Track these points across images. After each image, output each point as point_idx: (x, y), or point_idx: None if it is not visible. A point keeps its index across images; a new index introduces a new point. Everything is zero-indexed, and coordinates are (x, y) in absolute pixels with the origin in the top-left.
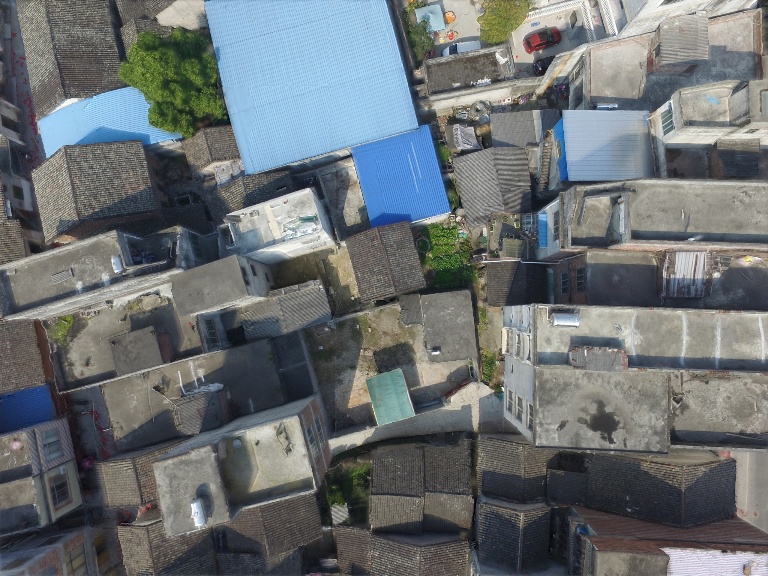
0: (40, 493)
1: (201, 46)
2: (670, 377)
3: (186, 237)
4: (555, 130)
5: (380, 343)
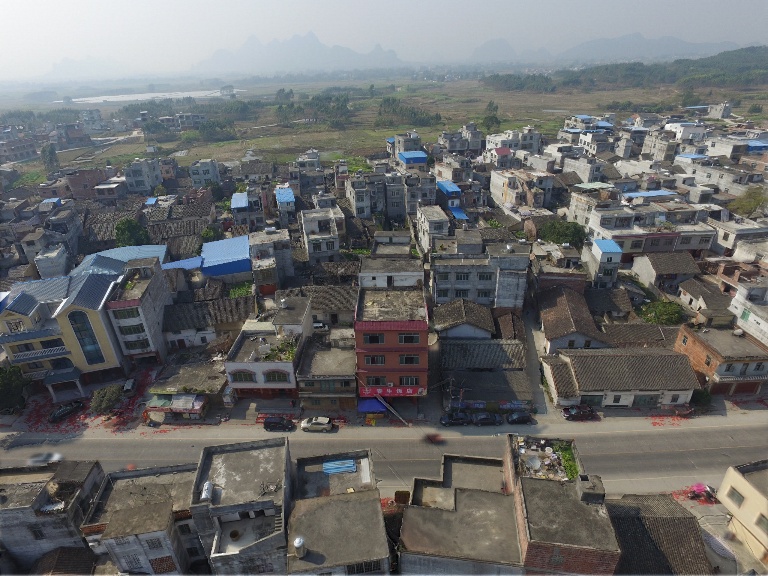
0: (3, 225)
1: None
2: None
3: (63, 239)
4: None
5: None
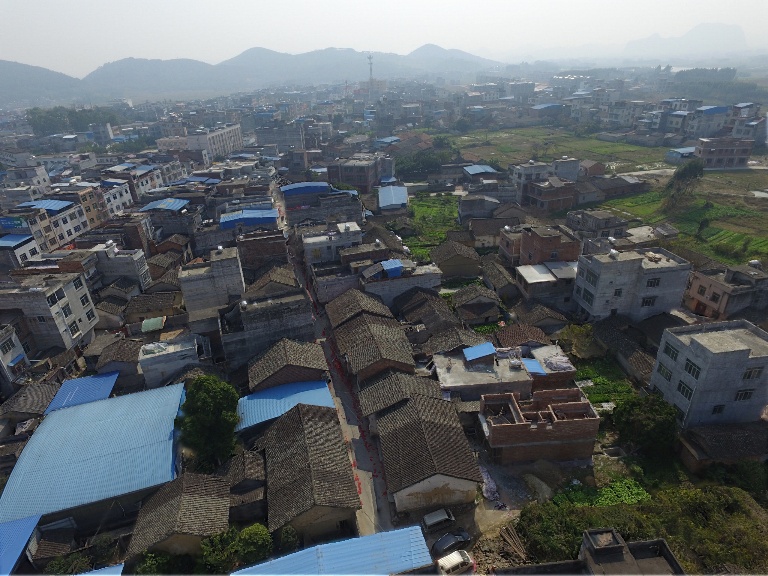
0: None
1: None
2: None
3: None
4: None
5: None
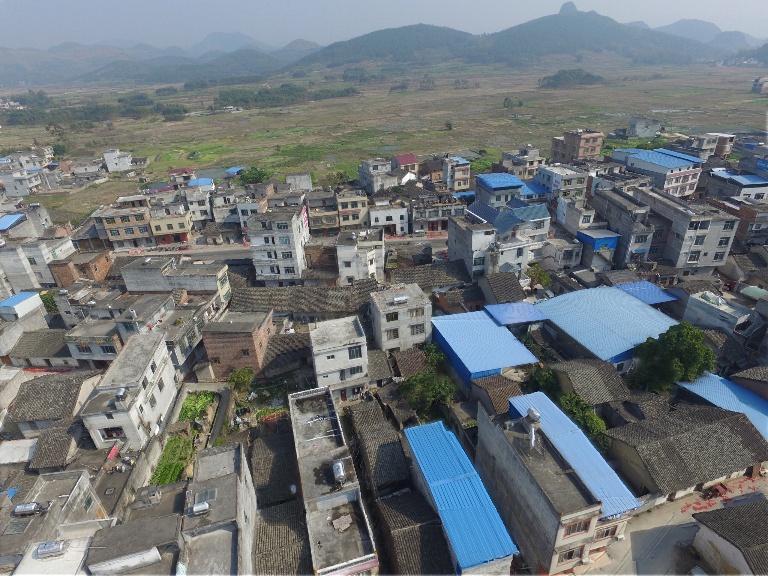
0: None
1: None
2: None
3: None
4: (597, 248)
5: None
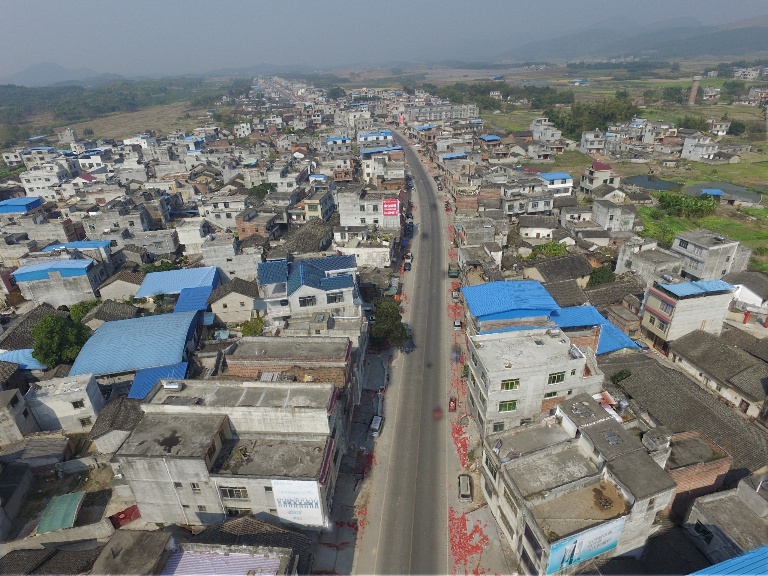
0: None
1: (87, 331)
2: (225, 417)
3: None
4: None
5: (88, 489)
